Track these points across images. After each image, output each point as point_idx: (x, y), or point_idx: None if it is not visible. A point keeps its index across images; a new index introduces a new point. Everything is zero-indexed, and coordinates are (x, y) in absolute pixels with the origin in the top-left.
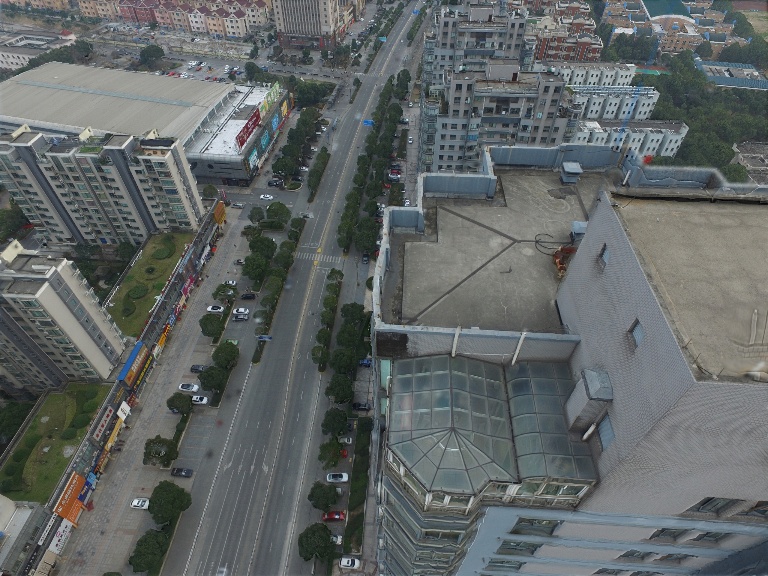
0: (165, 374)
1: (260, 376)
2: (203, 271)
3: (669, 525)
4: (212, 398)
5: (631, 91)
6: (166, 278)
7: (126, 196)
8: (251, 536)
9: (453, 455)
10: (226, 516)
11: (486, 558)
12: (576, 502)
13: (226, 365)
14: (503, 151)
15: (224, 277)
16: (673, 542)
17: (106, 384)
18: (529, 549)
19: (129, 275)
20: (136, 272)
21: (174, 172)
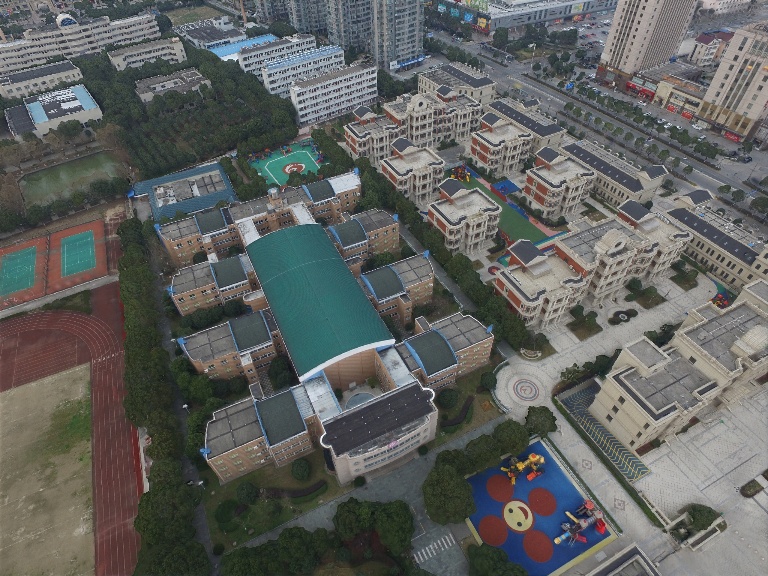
0: None
1: None
2: None
3: None
4: None
5: None
6: None
7: None
8: None
9: None
10: None
11: None
12: None
13: None
14: None
15: None
16: None
17: None
18: None
19: None
20: None
21: None
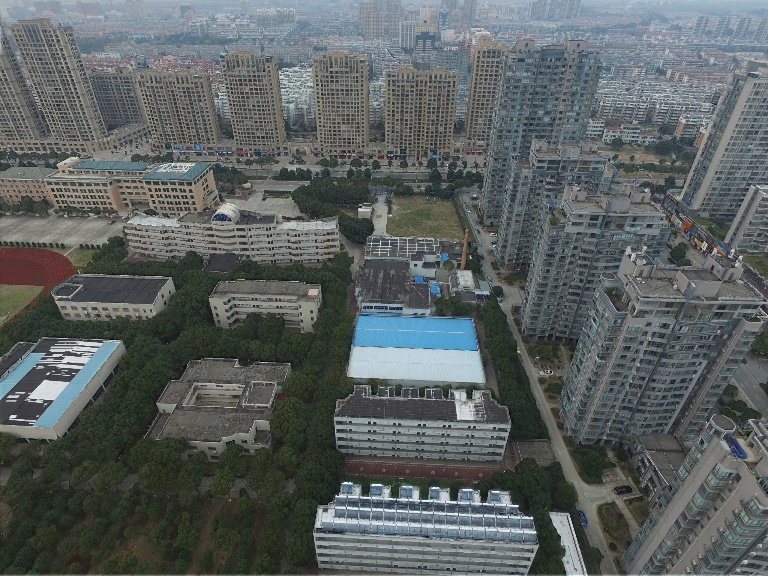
0: None
1: None
2: None
3: None
4: None
5: (372, 511)
6: (767, 279)
7: None
8: None
9: None
10: None
11: None
12: None
13: None
14: (594, 55)
15: None
16: None
17: None
18: None
19: None
20: None
21: None
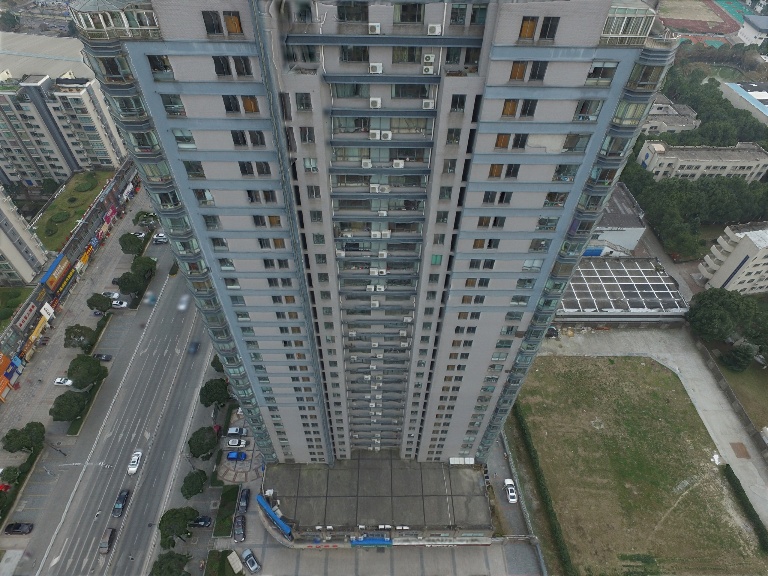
0: (88, 287)
1: (176, 285)
2: (127, 206)
3: (214, 53)
4: (131, 302)
5: None
6: (88, 206)
7: (46, 134)
8: (162, 399)
9: (94, 2)
10: (141, 387)
11: (169, 130)
12: (159, 31)
13: (143, 274)
14: None
15: (146, 211)
16: (233, 79)
17: (29, 287)
18: (185, 115)
19: (52, 205)
20: (59, 202)
21: (91, 109)
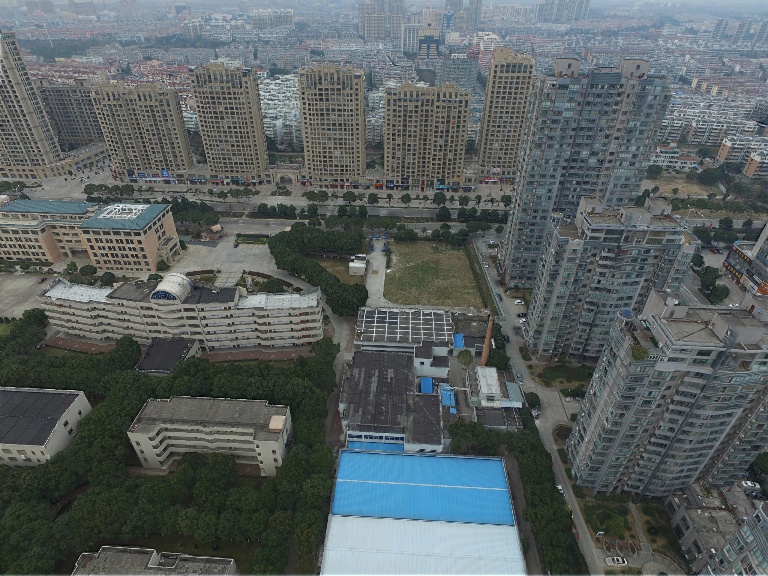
0: None
1: None
2: None
3: None
4: None
5: None
6: None
7: None
8: None
9: None
10: None
11: None
12: None
13: None
14: None
15: None
16: None
17: None
18: None
19: None
20: None
21: None
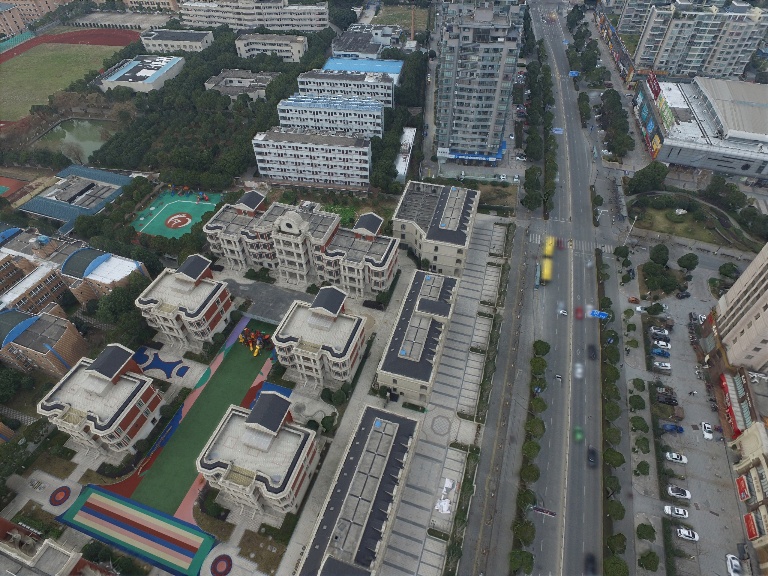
0: None
1: (562, 48)
2: None
3: None
4: None
5: (306, 101)
6: None
7: None
8: None
9: None
10: None
11: None
12: None
13: None
14: None
15: None
16: None
17: None
18: None
19: None
20: None
21: None
